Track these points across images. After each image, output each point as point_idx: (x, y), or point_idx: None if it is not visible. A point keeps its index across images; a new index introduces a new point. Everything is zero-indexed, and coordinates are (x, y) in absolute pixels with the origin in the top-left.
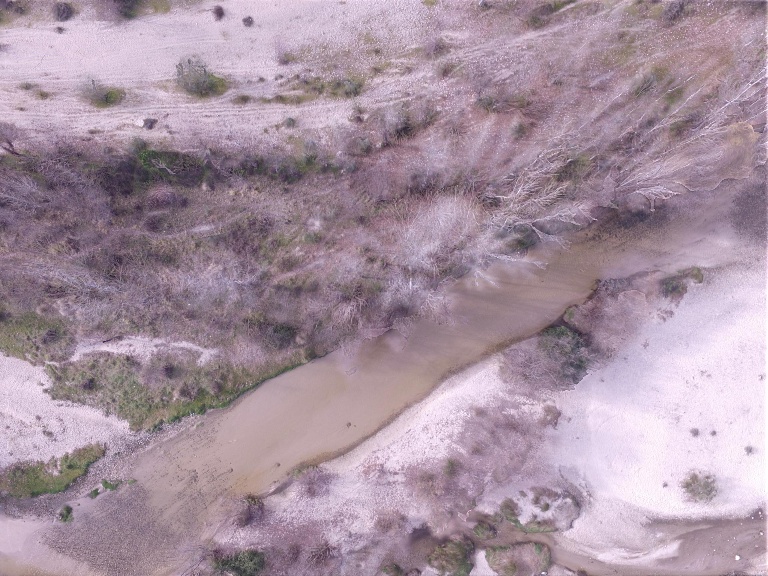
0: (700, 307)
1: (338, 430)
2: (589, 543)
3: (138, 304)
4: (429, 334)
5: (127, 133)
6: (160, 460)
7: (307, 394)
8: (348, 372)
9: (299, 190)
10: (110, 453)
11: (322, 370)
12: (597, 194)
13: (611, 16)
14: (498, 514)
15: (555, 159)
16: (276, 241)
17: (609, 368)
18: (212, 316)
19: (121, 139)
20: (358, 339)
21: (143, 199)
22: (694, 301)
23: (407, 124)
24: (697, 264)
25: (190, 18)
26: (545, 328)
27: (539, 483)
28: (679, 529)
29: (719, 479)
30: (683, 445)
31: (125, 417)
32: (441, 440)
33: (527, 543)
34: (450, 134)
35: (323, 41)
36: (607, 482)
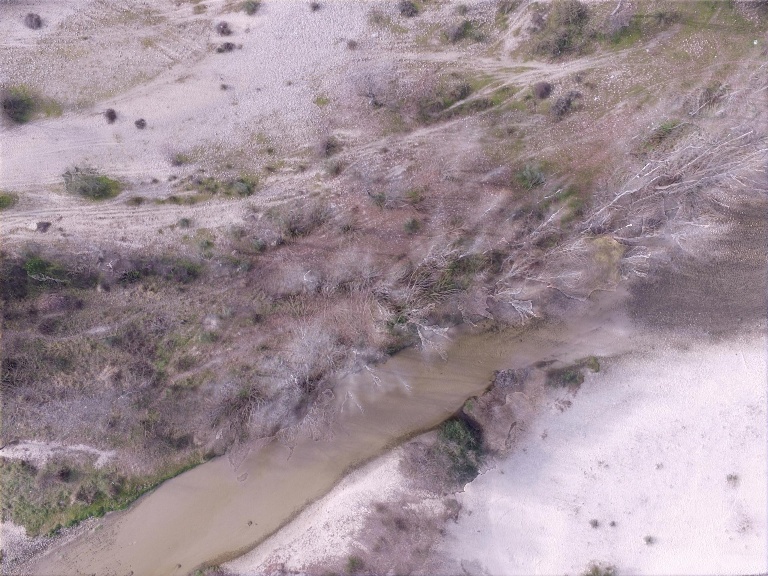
0: (597, 396)
1: (239, 529)
2: None
3: (33, 408)
4: None
5: (20, 237)
6: (58, 565)
7: (207, 493)
8: (239, 479)
9: (195, 289)
10: (7, 560)
11: (222, 468)
12: (472, 305)
13: (500, 112)
14: None
15: (448, 254)
16: (172, 341)
17: (509, 460)
18: (108, 418)
19: (15, 243)
20: (242, 451)
21: (37, 302)
22: (591, 390)
23: (300, 223)
24: (593, 353)
25: (82, 121)
26: (444, 421)
27: None
28: None
29: (619, 569)
30: (583, 536)
31: (21, 523)
32: (342, 537)
33: None
34: (344, 231)
35: (216, 142)
36: (509, 575)
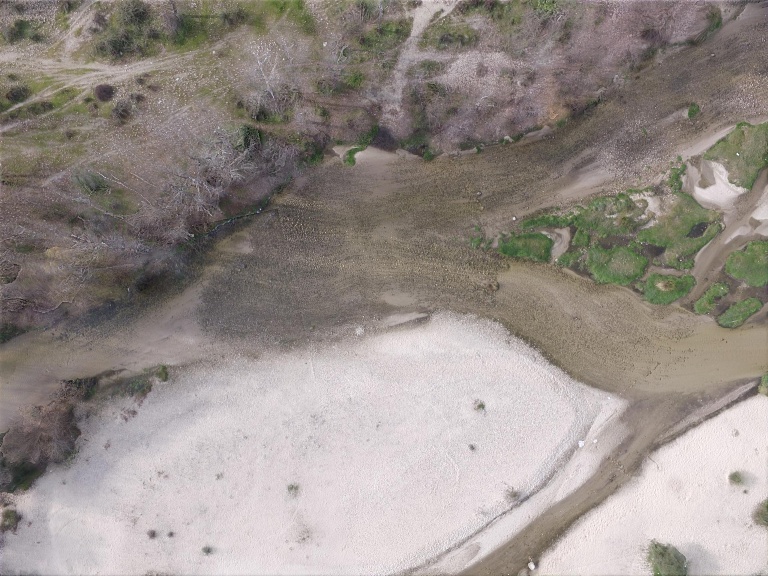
0: (163, 406)
1: None
2: None
3: None
4: None
5: None
6: None
7: None
8: None
9: None
10: None
11: None
12: None
13: (61, 115)
14: None
15: (3, 261)
16: None
17: (71, 470)
18: None
19: None
20: None
21: None
22: (158, 400)
23: None
24: (162, 362)
25: None
26: None
27: None
28: None
29: None
30: (140, 548)
31: None
32: None
33: None
34: None
35: None
36: None
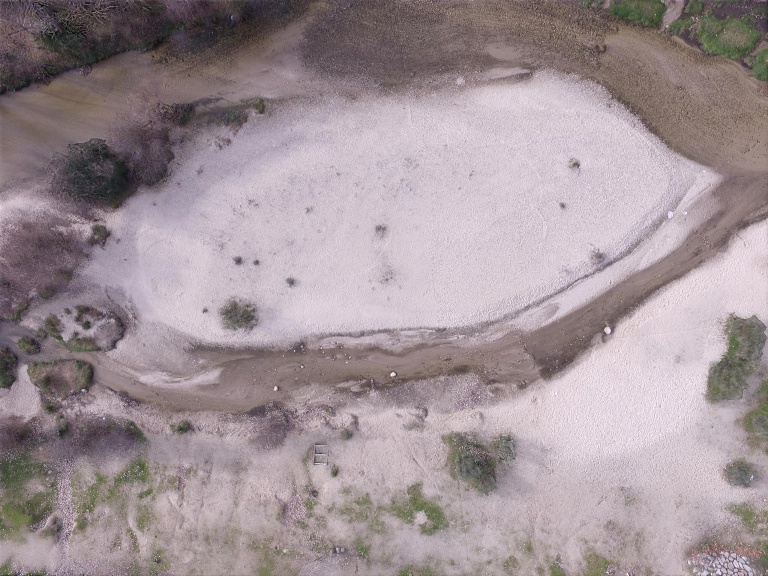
0: (258, 137)
1: None
2: (132, 365)
3: None
4: None
5: None
6: None
7: None
8: None
9: None
10: None
11: None
12: None
13: None
14: (42, 330)
15: None
16: None
17: (162, 192)
18: None
19: None
20: None
21: None
22: (253, 131)
23: None
24: (260, 94)
25: None
26: None
27: (85, 302)
28: (222, 357)
29: (260, 309)
30: (225, 272)
31: None
32: None
33: (70, 360)
34: None
35: None
36: (152, 305)
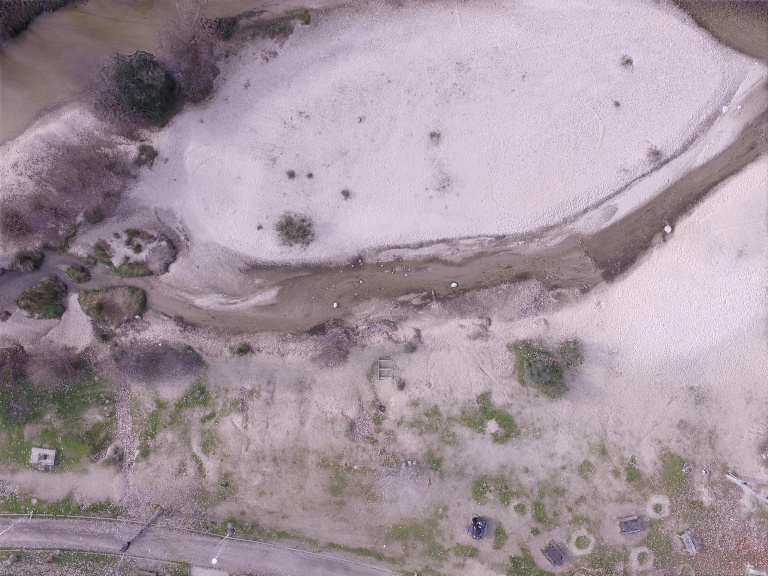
0: (305, 49)
1: None
2: (186, 288)
3: None
4: (24, 69)
5: None
6: None
7: None
8: None
9: None
10: None
11: None
12: None
13: None
14: (91, 256)
15: None
16: None
17: (210, 109)
18: None
19: None
20: None
21: None
22: (300, 43)
23: None
24: (305, 5)
25: None
26: None
27: (135, 225)
28: (278, 276)
29: (316, 223)
30: (279, 187)
31: None
32: (30, 177)
33: (121, 287)
34: None
35: None
36: (204, 225)
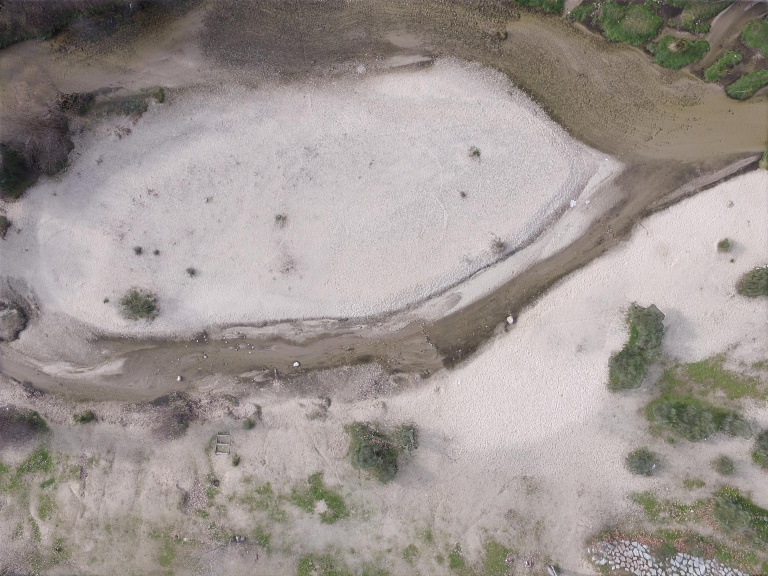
0: (158, 127)
1: None
2: (35, 355)
3: None
4: None
5: None
6: None
7: None
8: None
9: None
10: None
11: None
12: None
13: None
14: None
15: None
16: None
17: (63, 182)
18: None
19: None
20: None
21: None
22: (153, 120)
23: None
24: (160, 83)
25: None
26: None
27: None
28: (125, 347)
29: (161, 299)
30: (126, 262)
31: None
32: None
33: None
34: None
35: None
36: (53, 296)
